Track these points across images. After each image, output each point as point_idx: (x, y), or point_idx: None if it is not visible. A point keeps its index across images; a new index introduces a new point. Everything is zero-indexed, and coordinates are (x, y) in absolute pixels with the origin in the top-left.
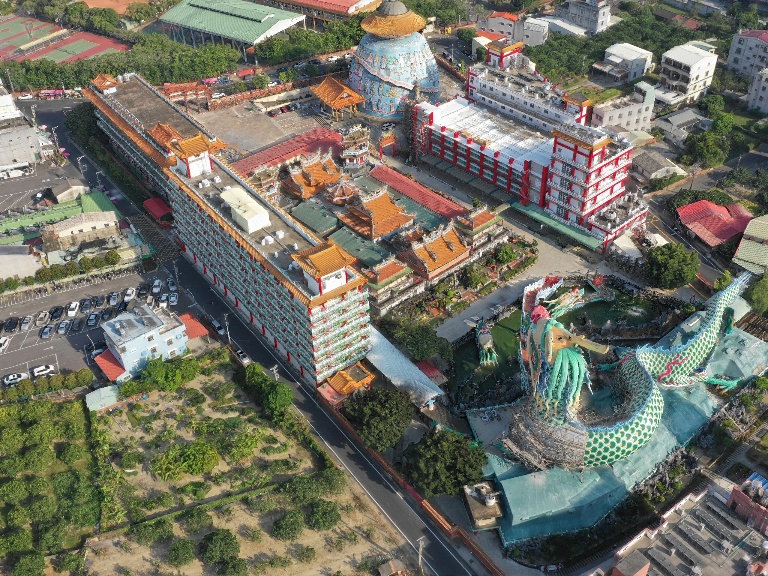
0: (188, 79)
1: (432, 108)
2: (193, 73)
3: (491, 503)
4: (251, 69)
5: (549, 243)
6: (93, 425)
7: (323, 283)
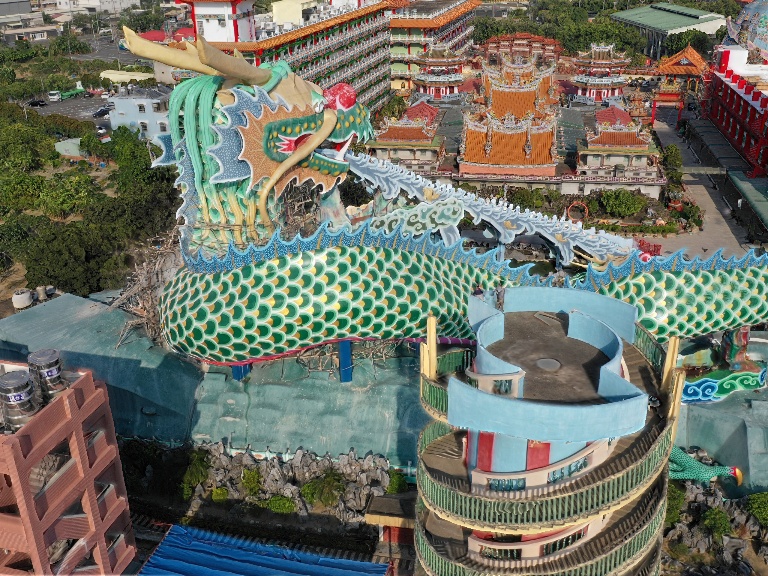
0: (570, 52)
1: (735, 48)
2: (577, 46)
3: (13, 300)
4: (648, 59)
5: (735, 232)
6: (39, 157)
7: (201, 24)
